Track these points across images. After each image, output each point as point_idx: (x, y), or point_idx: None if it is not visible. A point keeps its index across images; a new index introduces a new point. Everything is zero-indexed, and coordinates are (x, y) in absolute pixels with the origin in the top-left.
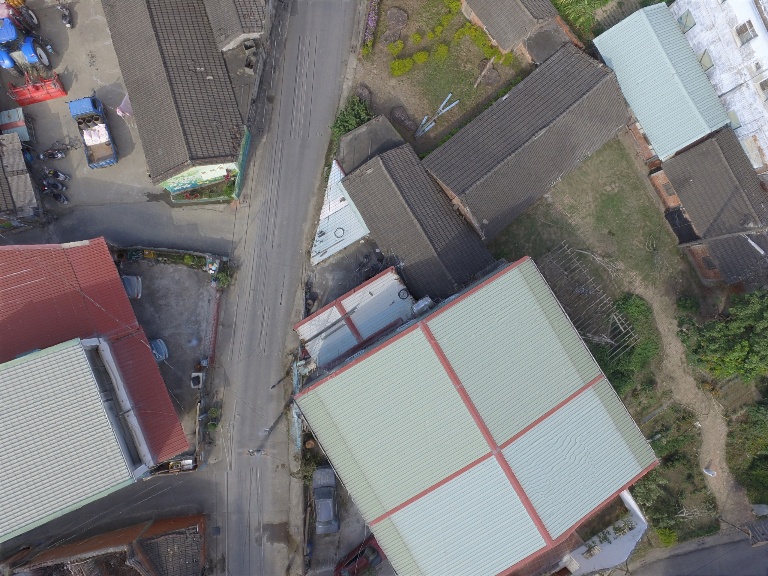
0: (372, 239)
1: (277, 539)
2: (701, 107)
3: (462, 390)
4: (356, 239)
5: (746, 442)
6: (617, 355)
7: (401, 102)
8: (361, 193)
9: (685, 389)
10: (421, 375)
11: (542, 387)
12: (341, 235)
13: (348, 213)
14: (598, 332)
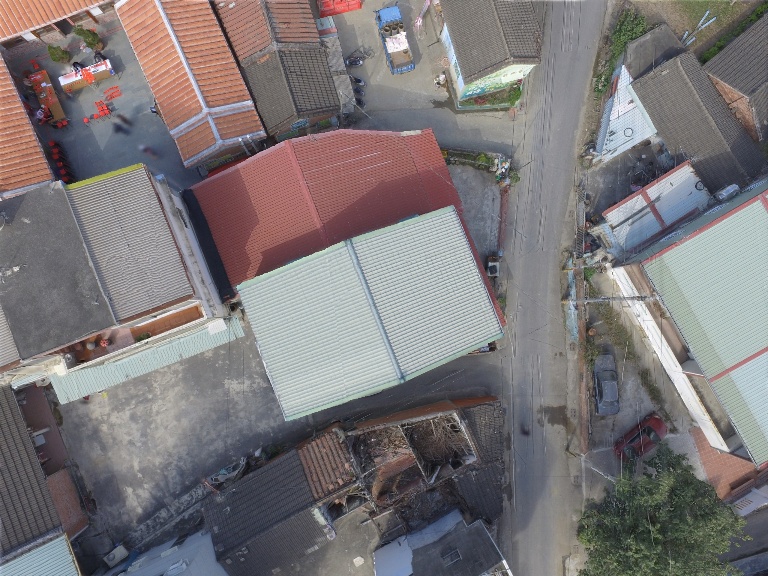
0: (639, 146)
1: (557, 421)
2: None
3: None
4: (644, 139)
5: None
6: None
7: (662, 18)
8: (652, 94)
9: None
10: (760, 244)
11: None
12: (630, 135)
13: (636, 114)
14: None
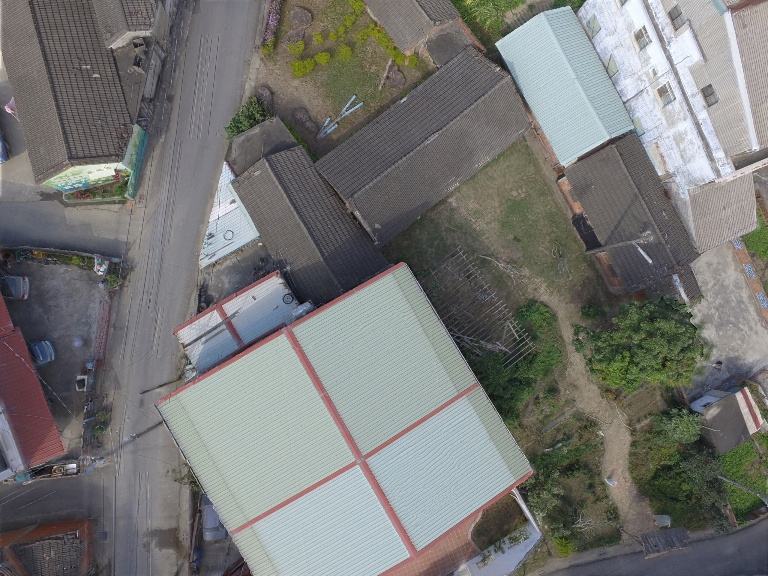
0: None
1: (166, 545)
2: (602, 113)
3: (326, 398)
4: (246, 242)
5: (649, 452)
6: (511, 363)
7: (304, 103)
8: (250, 195)
9: (589, 398)
10: (285, 382)
11: (413, 396)
12: (230, 238)
13: (238, 215)
14: (492, 339)
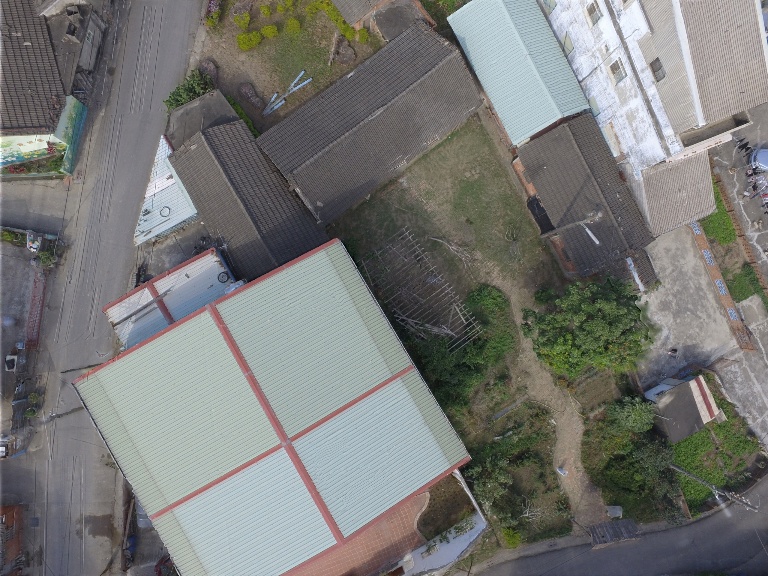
0: None
1: (100, 532)
2: (555, 91)
3: (251, 378)
4: (183, 219)
5: (603, 441)
6: (457, 347)
7: (250, 78)
8: (187, 170)
9: (541, 385)
10: (208, 361)
11: (344, 377)
12: (167, 214)
13: (175, 191)
14: (438, 323)
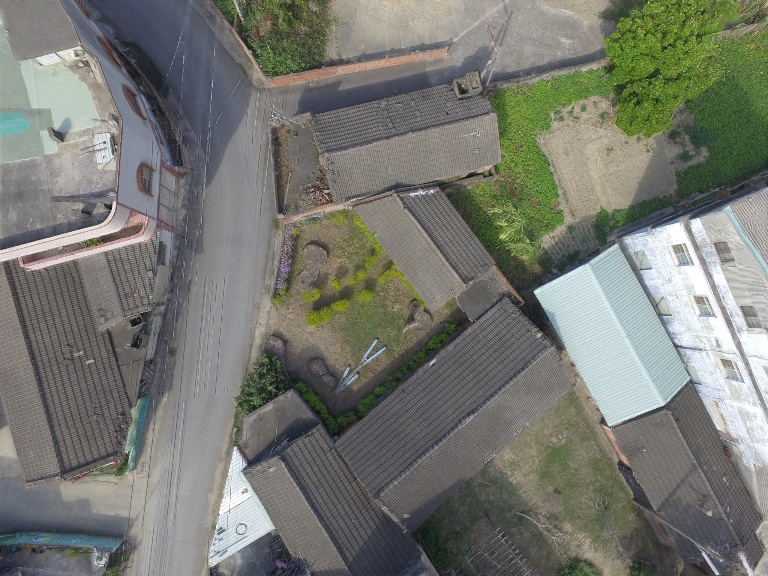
0: None
1: None
2: (655, 373)
3: None
4: (260, 536)
5: None
6: None
7: (320, 351)
8: (264, 488)
9: None
10: None
11: None
12: (243, 532)
13: (251, 506)
14: None
